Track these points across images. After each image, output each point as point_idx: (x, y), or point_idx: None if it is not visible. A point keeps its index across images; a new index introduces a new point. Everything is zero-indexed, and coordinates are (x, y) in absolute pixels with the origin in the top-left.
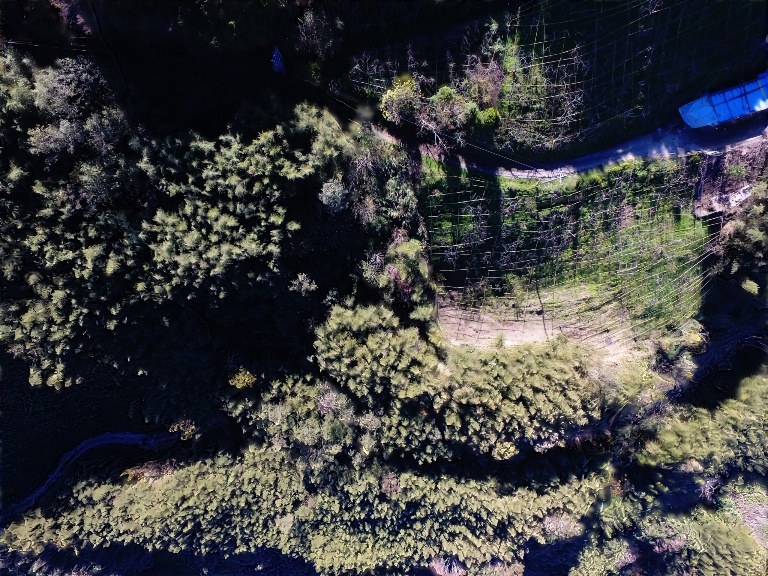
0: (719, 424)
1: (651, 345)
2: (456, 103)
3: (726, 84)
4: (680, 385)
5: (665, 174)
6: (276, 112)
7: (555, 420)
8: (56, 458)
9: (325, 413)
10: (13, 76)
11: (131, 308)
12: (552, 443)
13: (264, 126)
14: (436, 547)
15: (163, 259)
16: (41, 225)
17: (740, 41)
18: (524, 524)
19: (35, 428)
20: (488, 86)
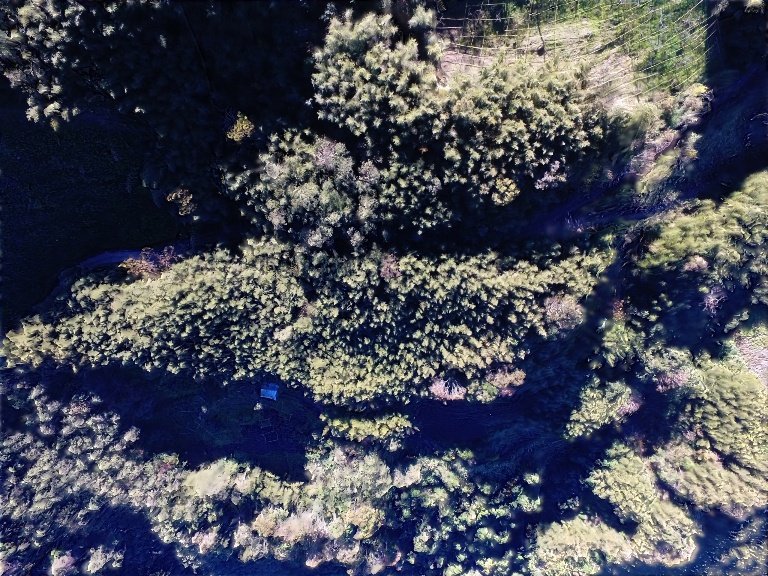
0: (723, 215)
1: (654, 108)
2: None
3: None
4: (684, 166)
5: None
6: None
7: (556, 137)
8: (55, 280)
9: (324, 180)
10: None
11: (128, 14)
12: (553, 176)
13: None
14: (436, 363)
15: None
16: None
17: None
18: (525, 306)
19: (34, 232)
20: None
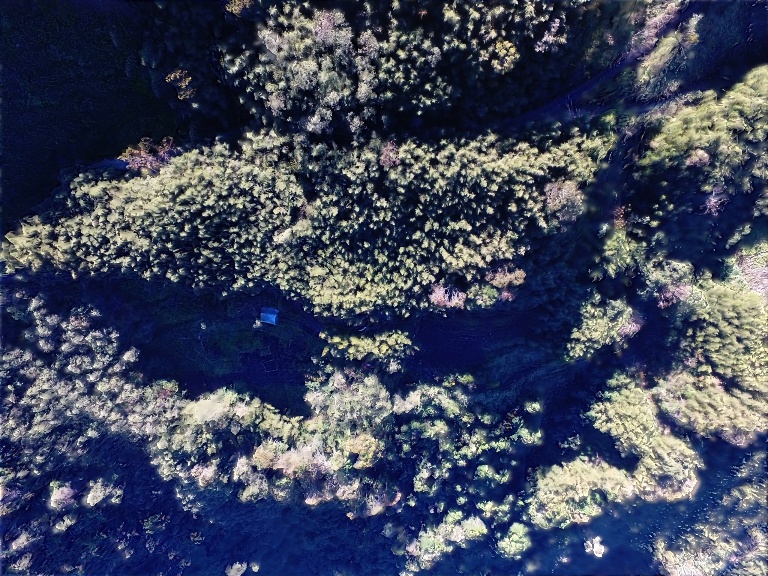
0: (725, 106)
1: None
2: None
3: None
4: (685, 52)
5: None
6: None
7: None
8: None
9: (323, 60)
10: None
11: None
12: (553, 37)
13: None
14: (436, 267)
15: None
16: None
17: None
18: (525, 192)
19: (33, 131)
20: None
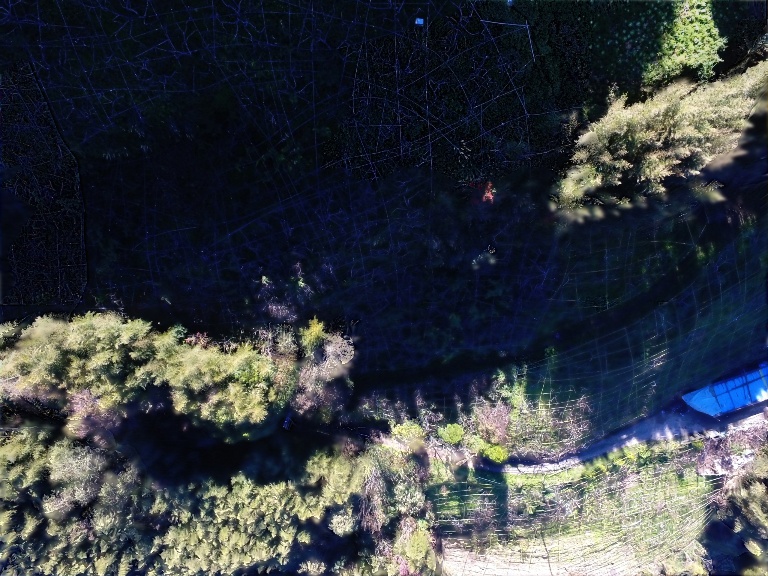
0: None
1: (655, 568)
2: (464, 441)
3: (728, 376)
4: None
5: None
6: (287, 465)
7: None
8: None
9: None
10: (29, 448)
11: None
12: None
13: (276, 478)
14: None
15: (174, 565)
16: (54, 551)
17: (742, 352)
18: None
19: None
20: (496, 431)
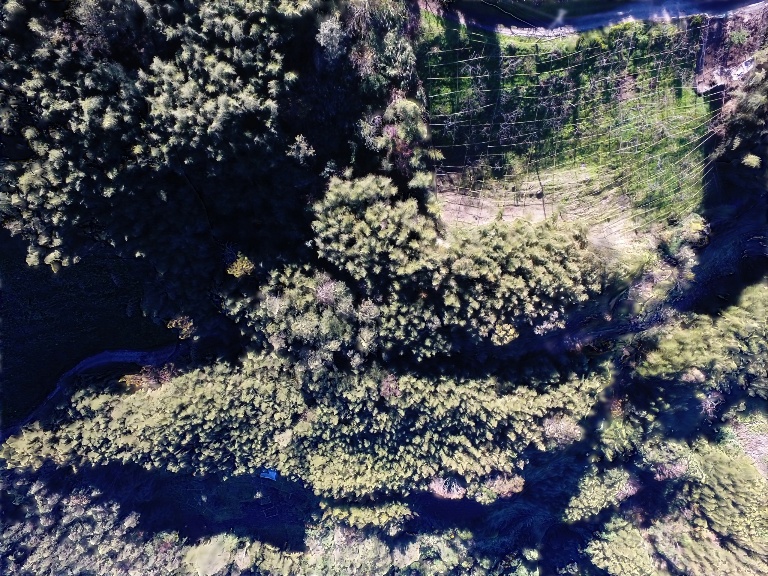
0: (721, 330)
1: (652, 239)
2: None
3: None
4: (681, 287)
5: (666, 40)
6: None
7: (555, 294)
8: (55, 378)
9: (324, 309)
10: None
11: (128, 176)
12: (552, 323)
13: None
14: (435, 464)
15: (160, 113)
16: (37, 69)
17: None
18: (524, 426)
19: (33, 340)
20: None
